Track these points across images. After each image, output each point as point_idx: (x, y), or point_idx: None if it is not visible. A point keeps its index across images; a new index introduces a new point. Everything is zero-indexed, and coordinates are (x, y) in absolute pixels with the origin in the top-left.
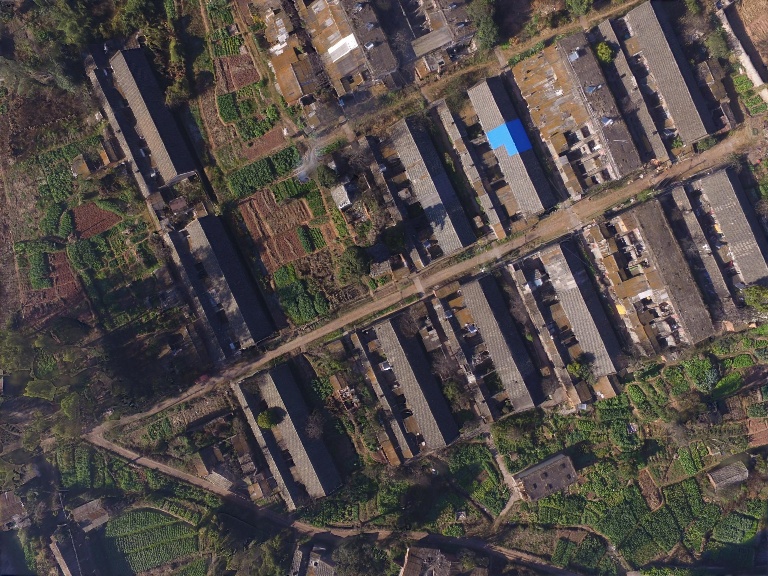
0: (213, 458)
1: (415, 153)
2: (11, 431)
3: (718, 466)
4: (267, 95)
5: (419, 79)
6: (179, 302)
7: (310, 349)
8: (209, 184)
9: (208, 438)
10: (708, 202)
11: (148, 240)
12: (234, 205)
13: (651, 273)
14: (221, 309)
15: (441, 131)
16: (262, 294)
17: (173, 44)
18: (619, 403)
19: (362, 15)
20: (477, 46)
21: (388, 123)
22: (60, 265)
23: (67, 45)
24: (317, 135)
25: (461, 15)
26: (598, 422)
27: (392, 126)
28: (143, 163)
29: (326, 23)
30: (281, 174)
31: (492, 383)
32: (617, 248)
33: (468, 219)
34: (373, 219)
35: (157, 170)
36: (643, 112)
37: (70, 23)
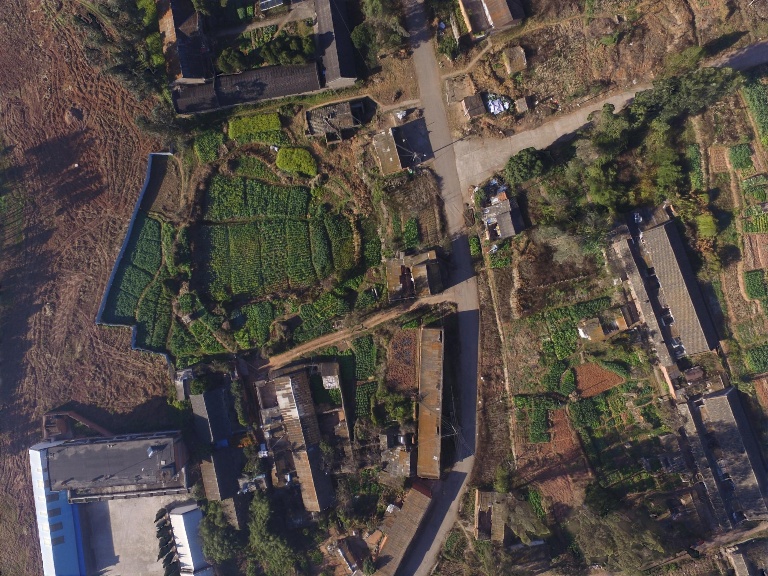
0: None
1: None
2: None
3: None
4: None
5: None
6: (686, 469)
7: None
8: (723, 356)
9: None
10: None
11: (652, 404)
12: (747, 379)
13: None
14: (726, 479)
15: None
16: (766, 466)
17: (708, 219)
18: None
19: None
20: None
21: None
22: (558, 421)
23: None
24: None
25: None
26: None
27: None
28: (665, 333)
29: None
30: None
31: None
32: None
33: None
34: None
35: (678, 341)
36: None
37: (608, 192)
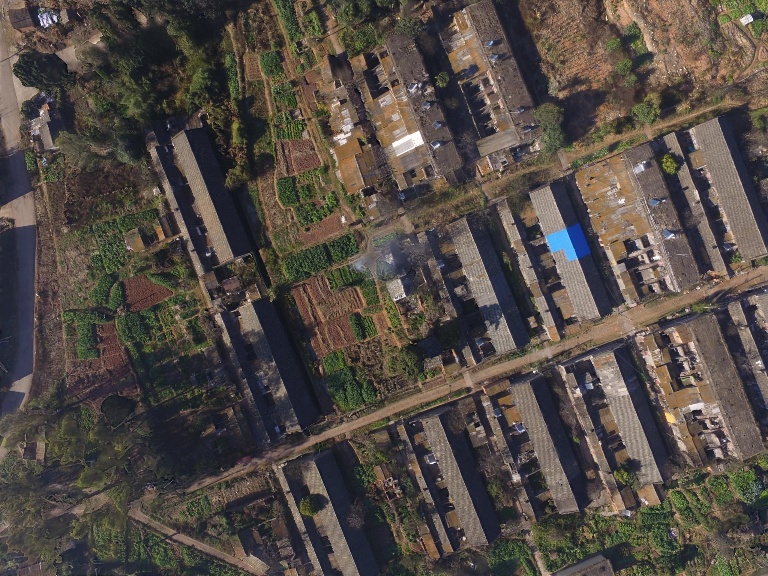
0: (251, 540)
1: (474, 252)
2: (48, 499)
3: (755, 573)
4: (327, 182)
5: (480, 175)
6: (226, 382)
7: (355, 436)
8: (263, 266)
9: (247, 519)
10: (763, 318)
11: (198, 317)
12: (287, 288)
13: (704, 387)
14: (268, 391)
15: (499, 229)
16: (310, 378)
17: (236, 126)
18: (661, 508)
19: (430, 113)
20: (540, 147)
21: (447, 217)
22: (108, 336)
23: (129, 119)
24: (375, 225)
25: (528, 119)
26: (639, 525)
27: (452, 223)
28: (199, 242)
29: (392, 118)
30: (337, 261)
31: (536, 482)
32: (670, 358)
33: (522, 319)
34: (427, 312)
35: (212, 250)
36: (704, 226)
37: (134, 99)
